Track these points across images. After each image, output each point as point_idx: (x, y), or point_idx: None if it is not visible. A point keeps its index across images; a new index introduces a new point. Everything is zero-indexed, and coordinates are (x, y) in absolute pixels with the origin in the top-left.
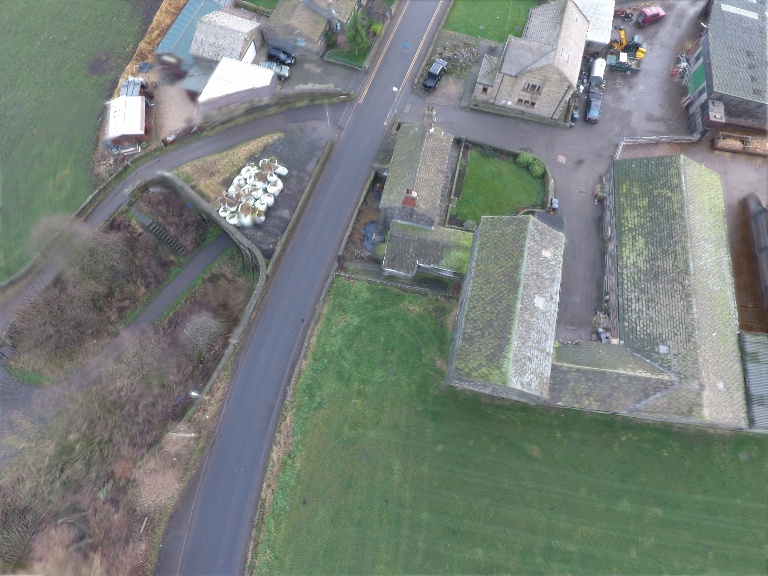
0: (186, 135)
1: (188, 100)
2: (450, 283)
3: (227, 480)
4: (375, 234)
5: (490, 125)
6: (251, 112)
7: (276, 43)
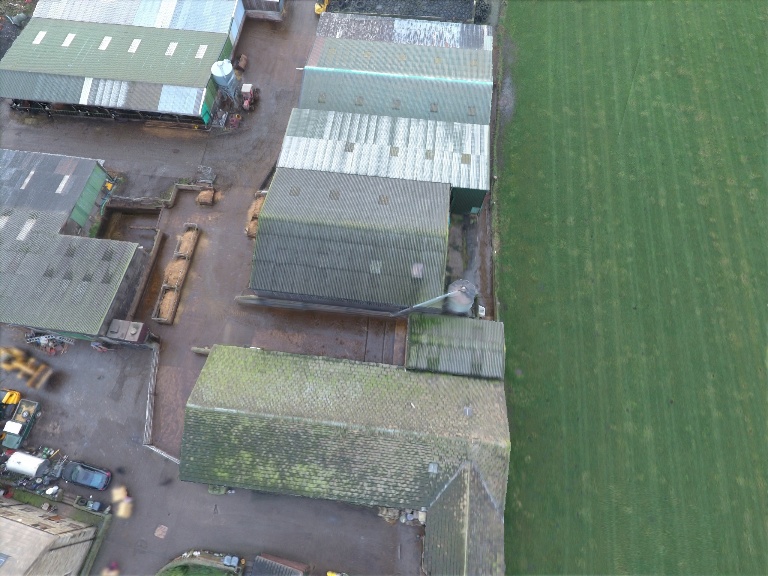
0: None
1: None
2: None
3: None
4: None
5: None
6: None
7: None
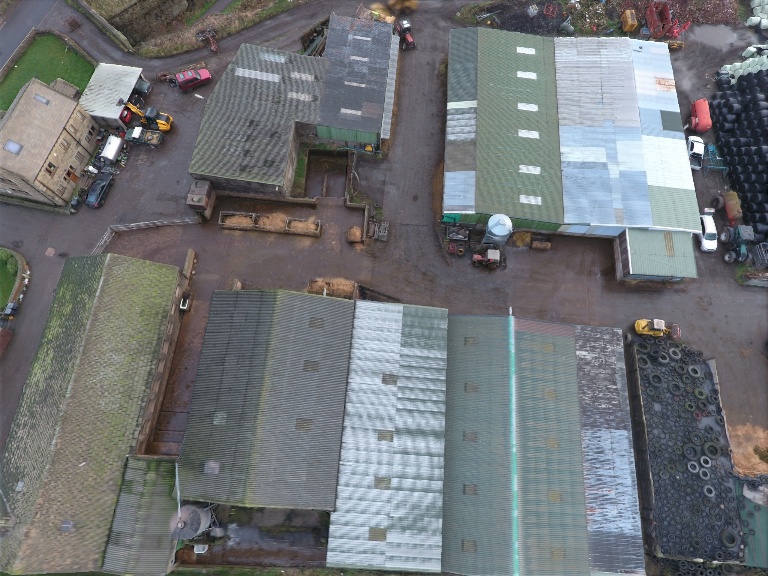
0: None
1: None
2: None
3: None
4: None
5: None
6: None
7: None
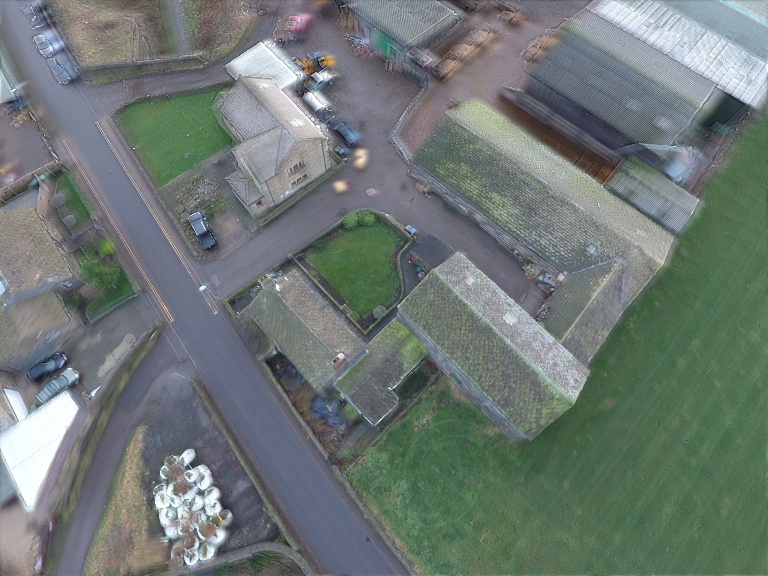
0: (48, 539)
1: (4, 509)
2: (422, 369)
3: None
4: (328, 406)
5: (293, 223)
6: (86, 444)
7: (26, 362)
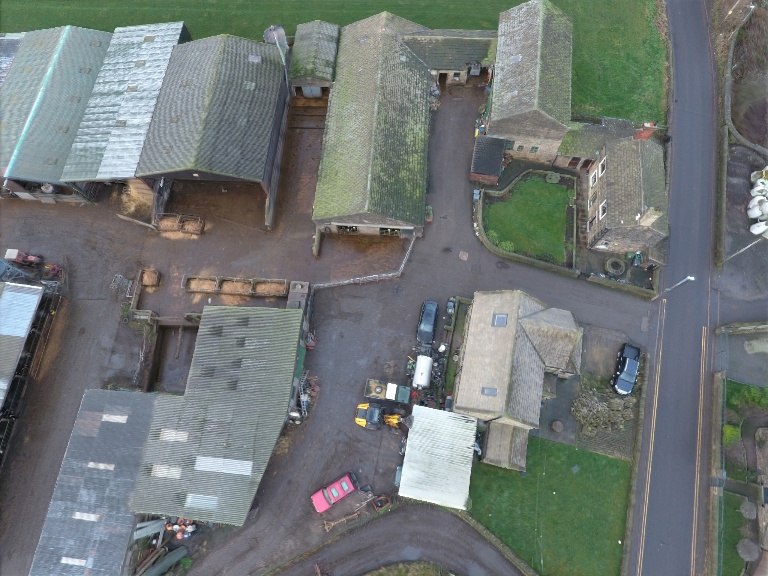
0: None
1: None
2: None
3: (688, 8)
4: None
5: (545, 299)
6: None
7: None
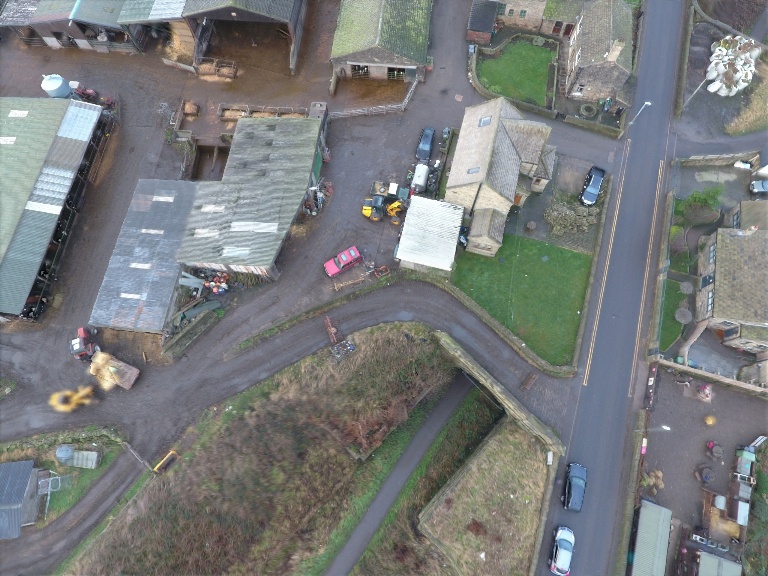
0: None
1: None
2: None
3: None
4: None
5: None
6: None
7: None
